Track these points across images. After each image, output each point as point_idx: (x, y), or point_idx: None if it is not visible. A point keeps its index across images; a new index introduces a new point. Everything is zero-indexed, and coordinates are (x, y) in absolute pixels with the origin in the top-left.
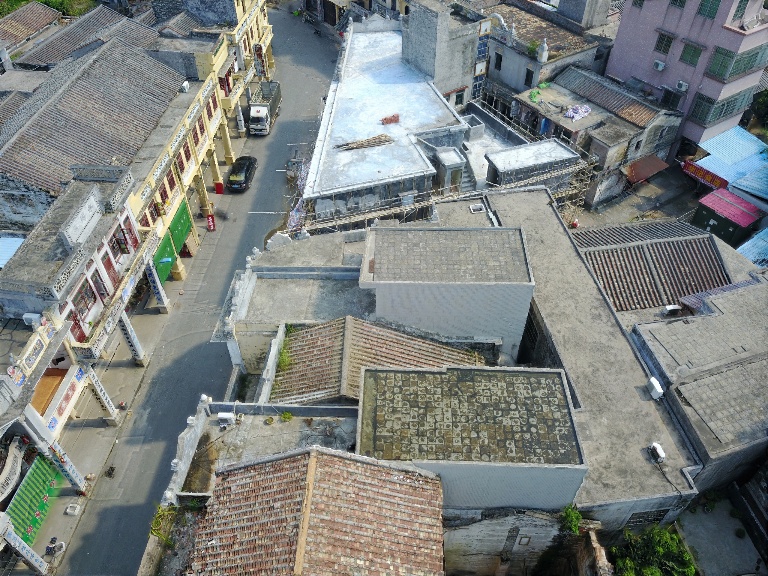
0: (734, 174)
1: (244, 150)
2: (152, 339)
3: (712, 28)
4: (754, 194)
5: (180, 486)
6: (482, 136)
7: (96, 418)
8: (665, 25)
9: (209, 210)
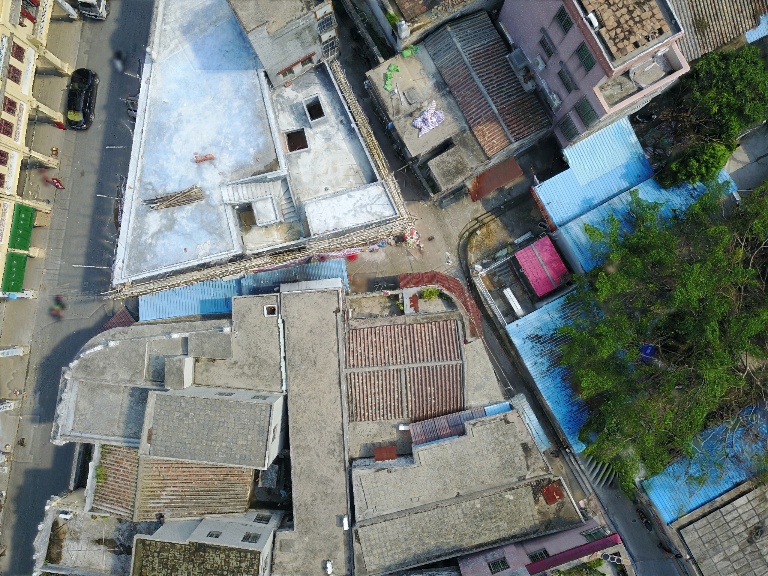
0: (579, 202)
1: (82, 45)
2: (28, 326)
3: (586, 77)
4: (573, 249)
5: (44, 558)
6: (327, 121)
7: (1, 399)
8: (550, 31)
9: (53, 165)
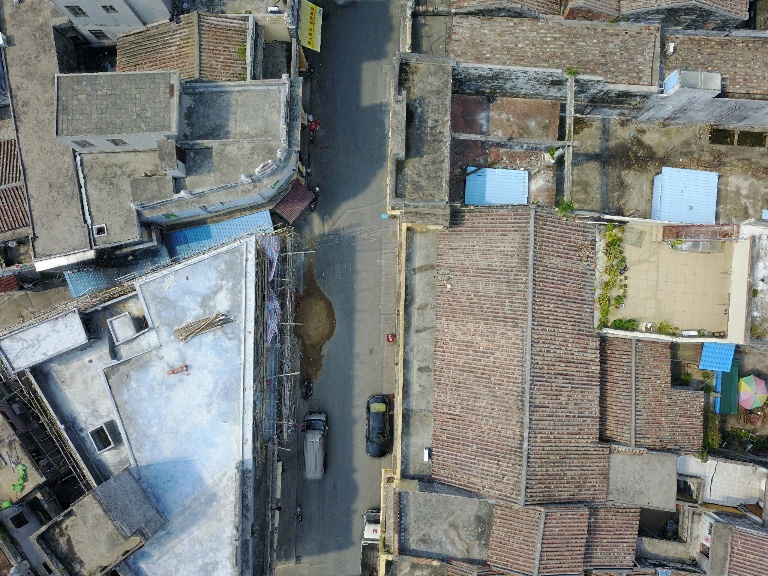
0: None
1: None
2: None
3: None
4: None
5: None
6: None
7: None
8: None
9: None
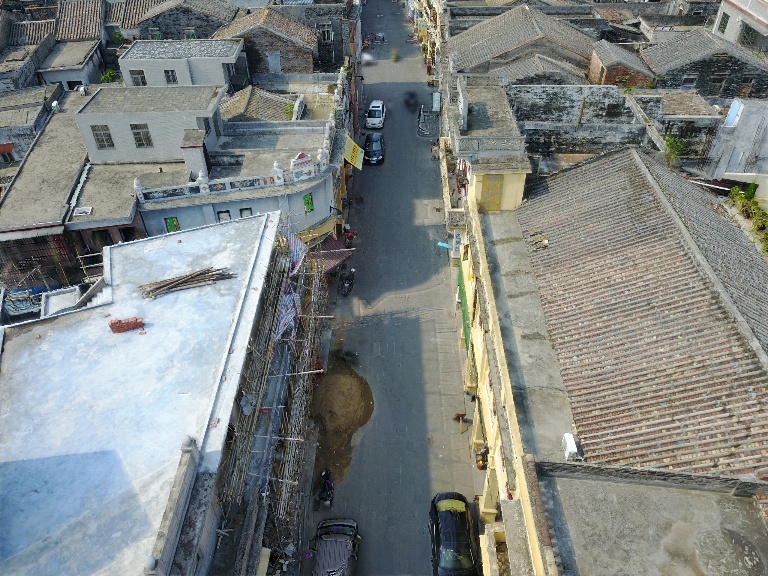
0: None
1: None
2: None
3: None
4: None
5: None
6: None
7: None
8: None
9: None
